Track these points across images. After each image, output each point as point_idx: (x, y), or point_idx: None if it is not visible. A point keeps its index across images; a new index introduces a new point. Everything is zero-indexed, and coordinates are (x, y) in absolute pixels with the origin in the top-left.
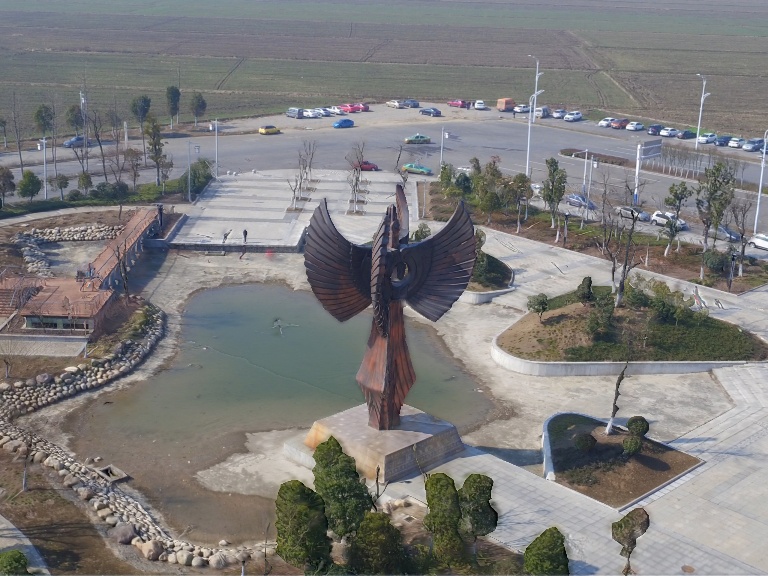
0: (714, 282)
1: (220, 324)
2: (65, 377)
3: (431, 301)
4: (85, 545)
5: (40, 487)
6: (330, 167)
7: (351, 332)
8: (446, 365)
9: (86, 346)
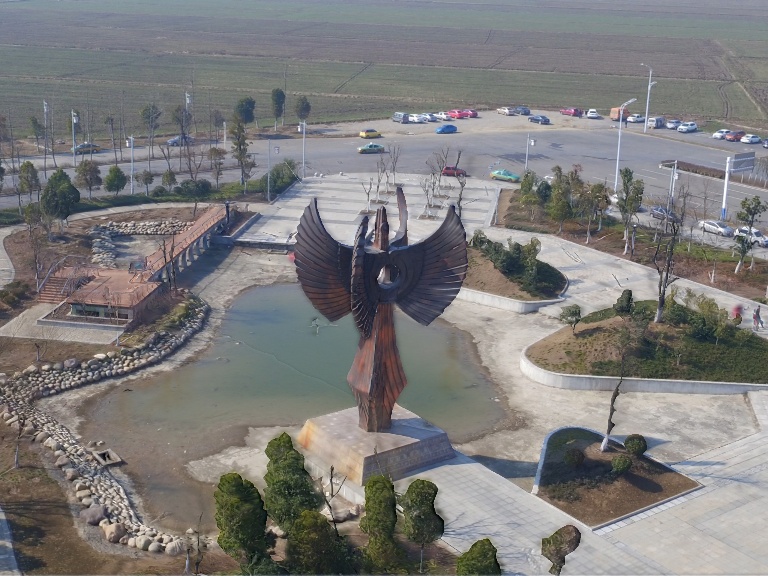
0: None
1: (261, 321)
2: (92, 363)
3: (422, 305)
4: (54, 523)
5: (31, 465)
6: (419, 172)
7: None
8: (471, 372)
9: (121, 335)
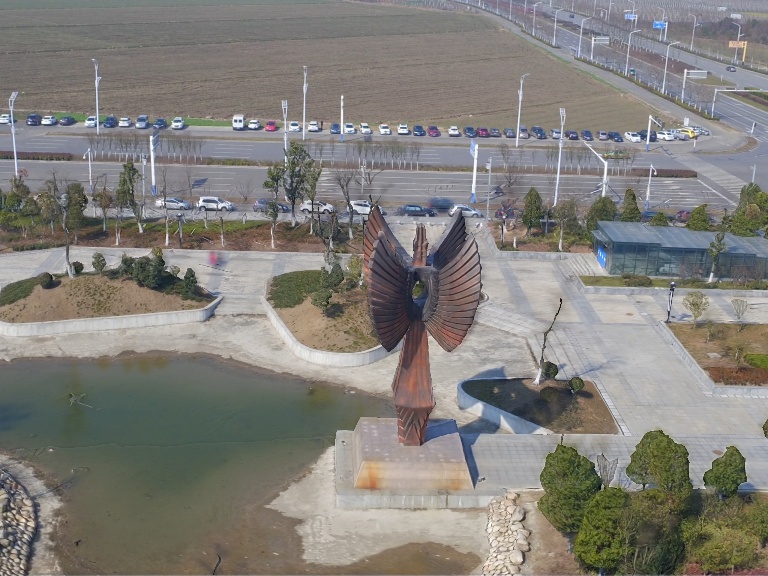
0: (346, 248)
1: (6, 421)
2: (5, 536)
3: None
4: None
5: None
6: None
7: (148, 383)
8: (286, 381)
9: None
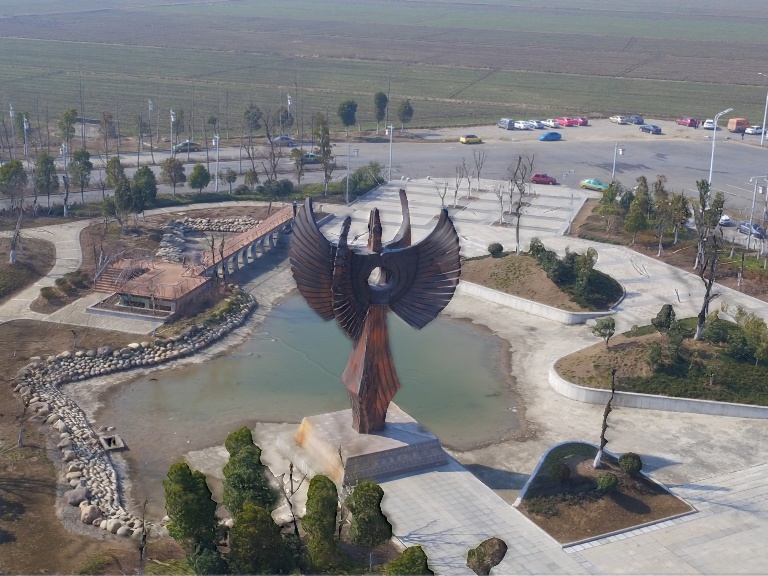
0: None
1: (304, 319)
2: (124, 352)
3: (416, 309)
4: (37, 501)
5: (34, 445)
6: None
7: (424, 339)
8: (497, 381)
9: (161, 326)
